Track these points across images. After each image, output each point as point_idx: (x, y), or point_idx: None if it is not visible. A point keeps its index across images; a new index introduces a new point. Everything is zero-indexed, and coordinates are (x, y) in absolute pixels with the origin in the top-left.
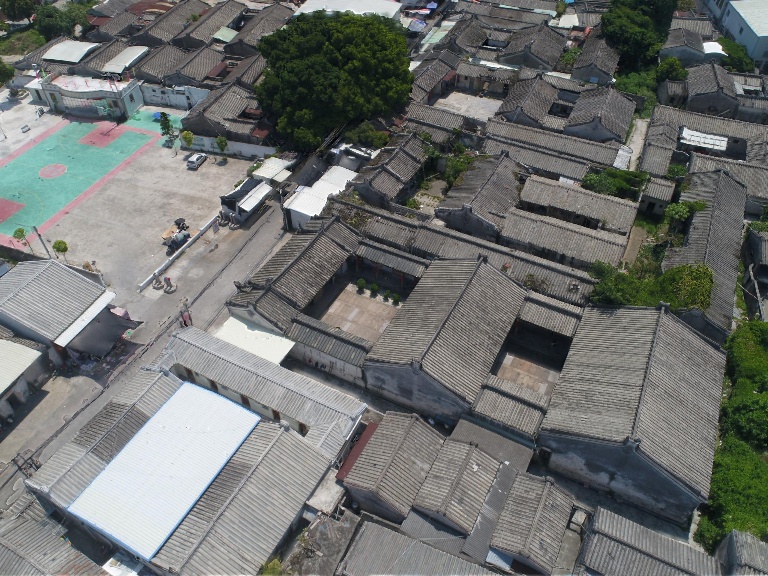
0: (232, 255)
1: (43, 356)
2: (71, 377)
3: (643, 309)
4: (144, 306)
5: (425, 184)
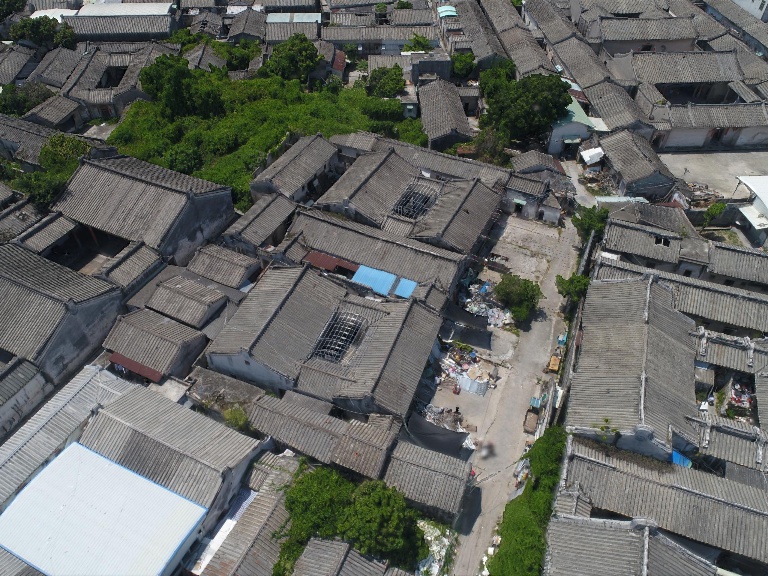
0: None
1: None
2: None
3: (77, 173)
4: None
5: None
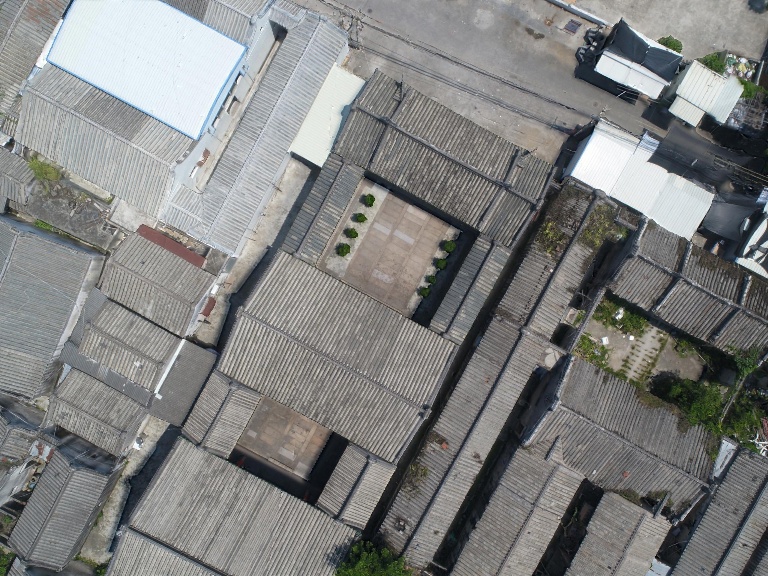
0: (520, 62)
1: None
2: None
3: None
4: None
5: (689, 346)
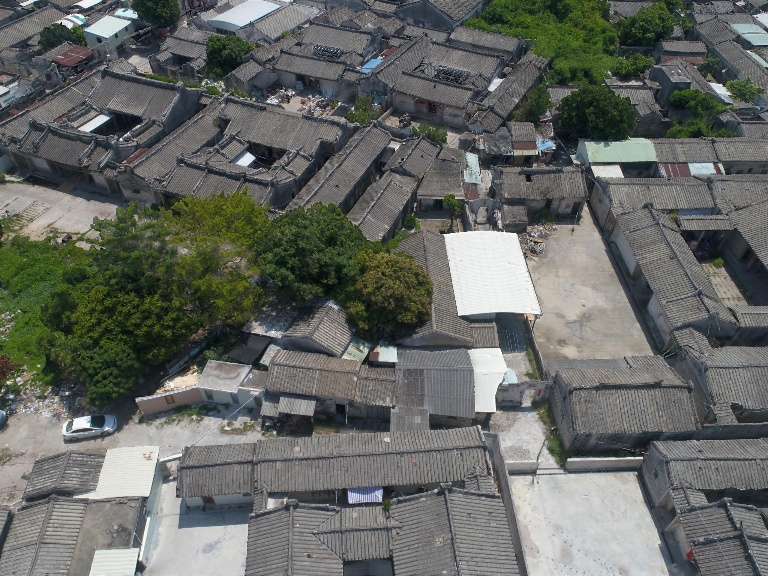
0: None
1: (183, 2)
2: (194, 16)
3: None
4: (223, 1)
5: None
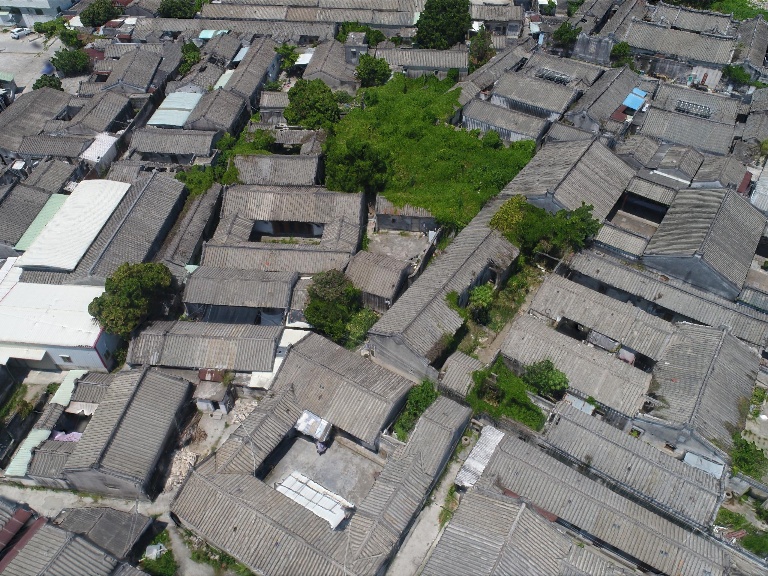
0: None
1: None
2: None
3: None
4: None
5: None
